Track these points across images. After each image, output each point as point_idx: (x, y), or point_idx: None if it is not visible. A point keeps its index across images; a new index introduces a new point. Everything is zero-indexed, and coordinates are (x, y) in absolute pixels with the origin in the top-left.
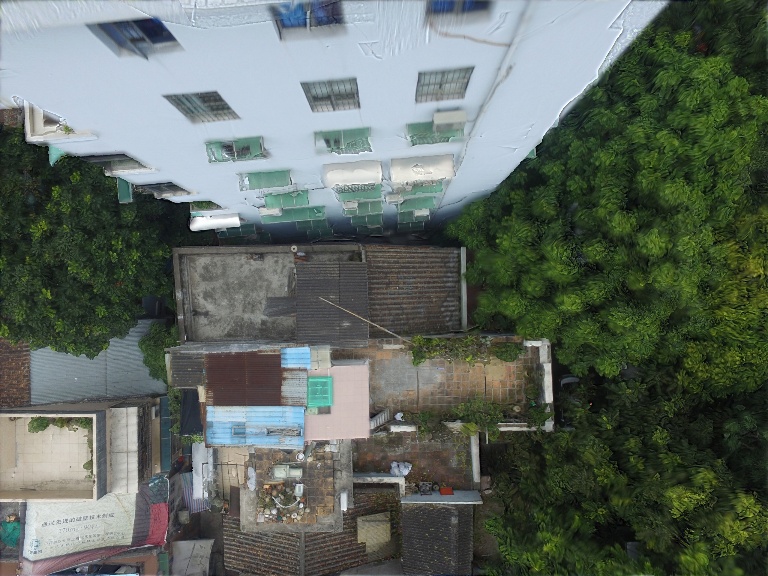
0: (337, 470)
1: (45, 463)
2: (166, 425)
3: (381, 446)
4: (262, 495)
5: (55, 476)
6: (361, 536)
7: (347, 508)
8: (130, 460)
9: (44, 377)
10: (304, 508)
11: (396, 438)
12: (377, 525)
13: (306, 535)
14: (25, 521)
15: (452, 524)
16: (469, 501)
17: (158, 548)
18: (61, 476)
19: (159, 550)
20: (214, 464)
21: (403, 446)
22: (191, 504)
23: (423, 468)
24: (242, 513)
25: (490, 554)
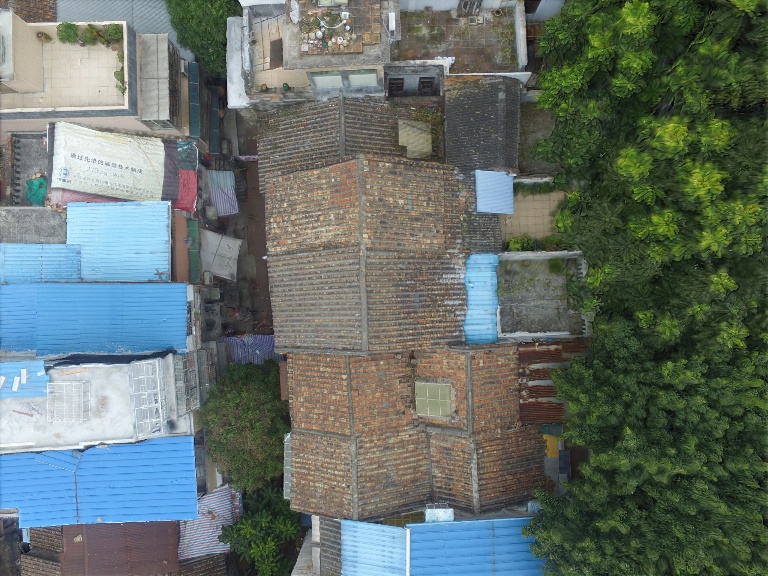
0: (384, 1)
1: (73, 88)
2: (194, 91)
3: (423, 43)
4: (307, 18)
5: (84, 100)
6: (402, 138)
7: (387, 117)
8: (161, 86)
9: (70, 16)
10: (350, 34)
11: (438, 35)
12: (418, 133)
13: (346, 130)
14: (53, 152)
15: (499, 100)
16: (517, 72)
17: (188, 212)
18: (90, 101)
19: (189, 215)
20: (250, 58)
21: (445, 43)
22: (218, 207)
23: (466, 64)
24: (285, 49)
25: (534, 168)
